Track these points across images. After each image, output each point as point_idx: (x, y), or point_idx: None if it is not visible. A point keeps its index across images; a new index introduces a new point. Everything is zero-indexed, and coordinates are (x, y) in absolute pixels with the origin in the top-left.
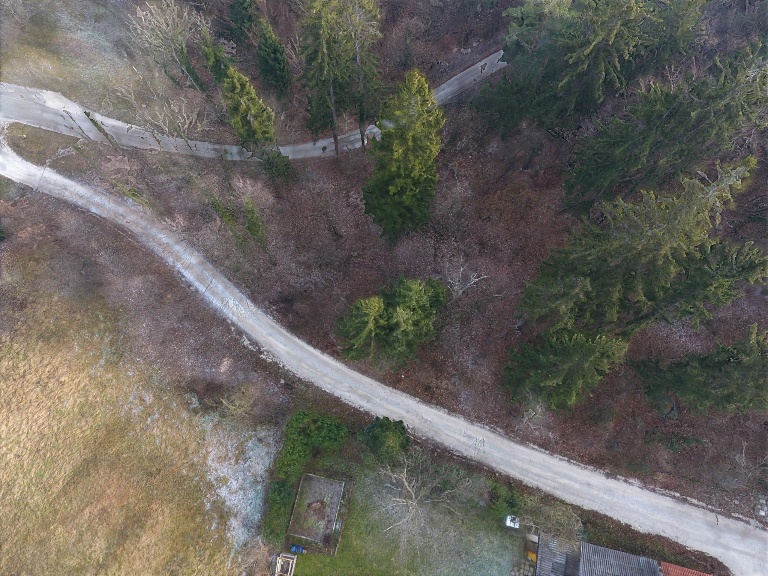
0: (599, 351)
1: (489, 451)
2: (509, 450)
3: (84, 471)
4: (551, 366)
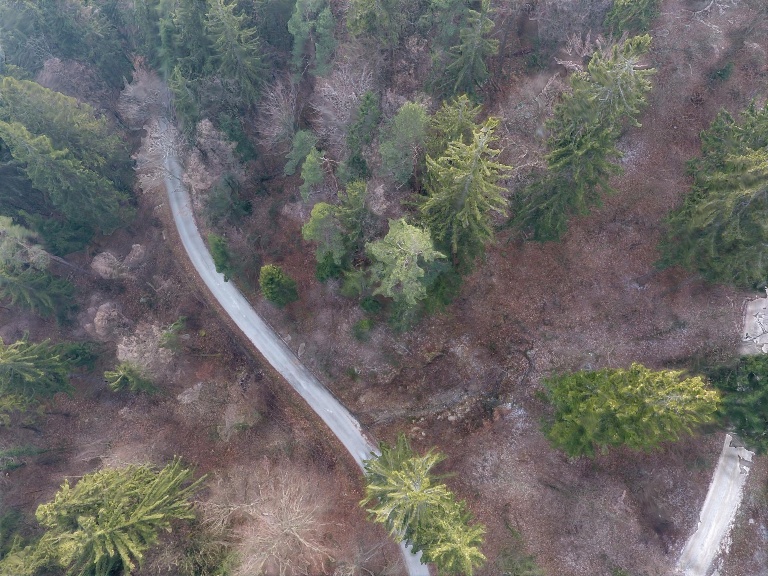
0: None
1: (763, 310)
2: None
3: None
4: None
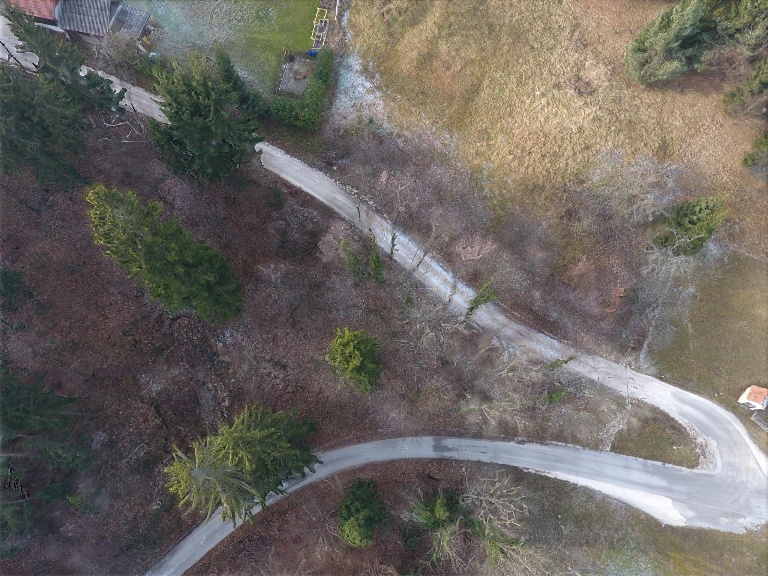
0: (16, 7)
1: None
2: (150, 110)
3: (471, 93)
4: (79, 89)
